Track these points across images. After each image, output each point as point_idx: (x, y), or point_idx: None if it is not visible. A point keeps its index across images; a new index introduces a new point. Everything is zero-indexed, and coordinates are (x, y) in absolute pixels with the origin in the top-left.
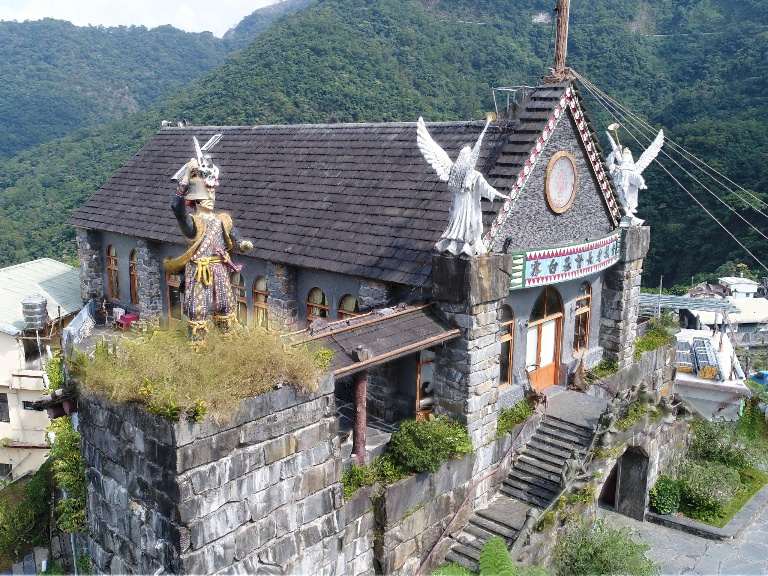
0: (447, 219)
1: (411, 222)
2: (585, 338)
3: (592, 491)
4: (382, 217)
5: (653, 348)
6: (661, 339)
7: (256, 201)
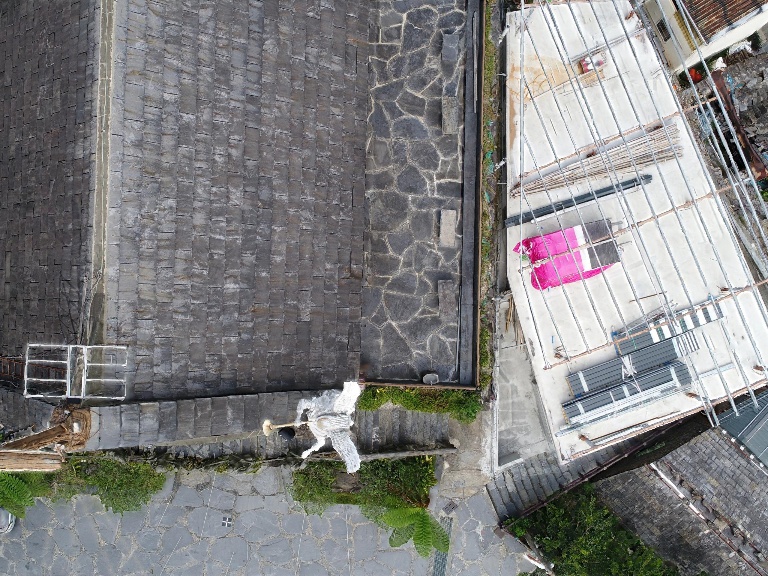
0: (3, 350)
1: (1, 304)
2: None
3: None
4: (4, 257)
5: (413, 409)
6: (438, 410)
7: (15, 12)
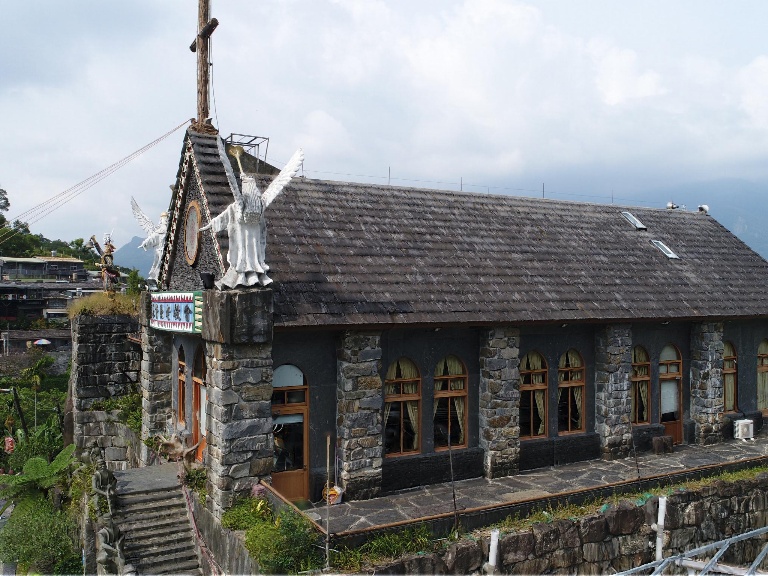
0: None
1: None
2: (199, 424)
3: (75, 500)
4: None
5: None
6: None
7: None
